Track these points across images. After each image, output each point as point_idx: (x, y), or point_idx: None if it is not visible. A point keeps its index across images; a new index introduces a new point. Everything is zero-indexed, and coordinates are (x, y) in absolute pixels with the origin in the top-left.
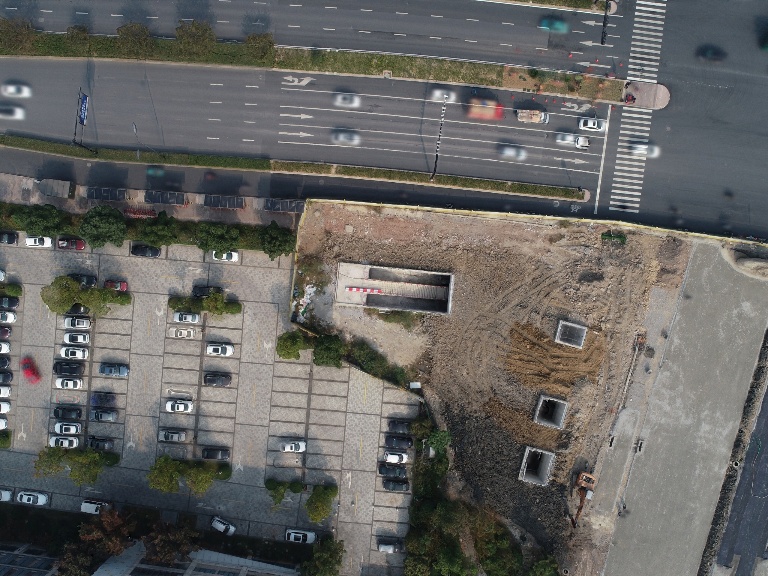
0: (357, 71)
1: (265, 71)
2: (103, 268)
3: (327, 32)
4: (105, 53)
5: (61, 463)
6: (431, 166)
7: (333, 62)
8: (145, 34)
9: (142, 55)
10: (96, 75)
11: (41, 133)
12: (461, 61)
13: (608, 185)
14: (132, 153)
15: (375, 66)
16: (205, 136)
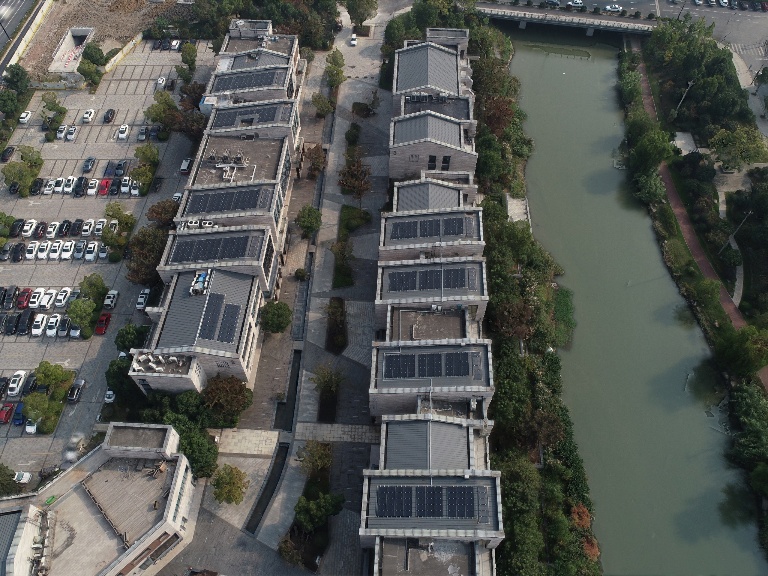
0: None
1: None
2: None
3: None
4: None
5: (154, 190)
6: (3, 42)
7: None
8: None
9: None
10: None
11: None
12: None
13: None
14: None
15: None
16: None
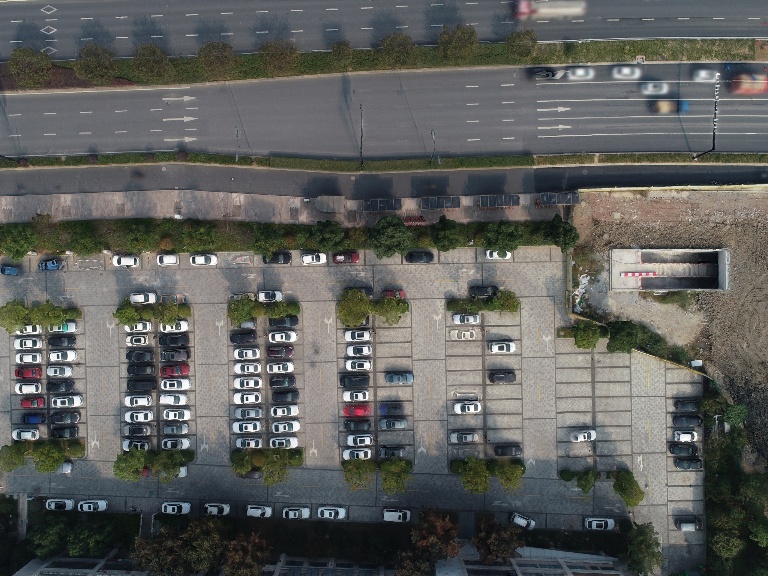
0: (610, 59)
1: (519, 68)
2: (377, 279)
3: (576, 24)
4: (361, 67)
5: None
6: (691, 145)
7: (586, 53)
8: (409, 43)
9: (407, 64)
10: (352, 89)
11: (303, 152)
12: (712, 39)
13: None
14: (397, 162)
15: (628, 52)
16: (465, 138)
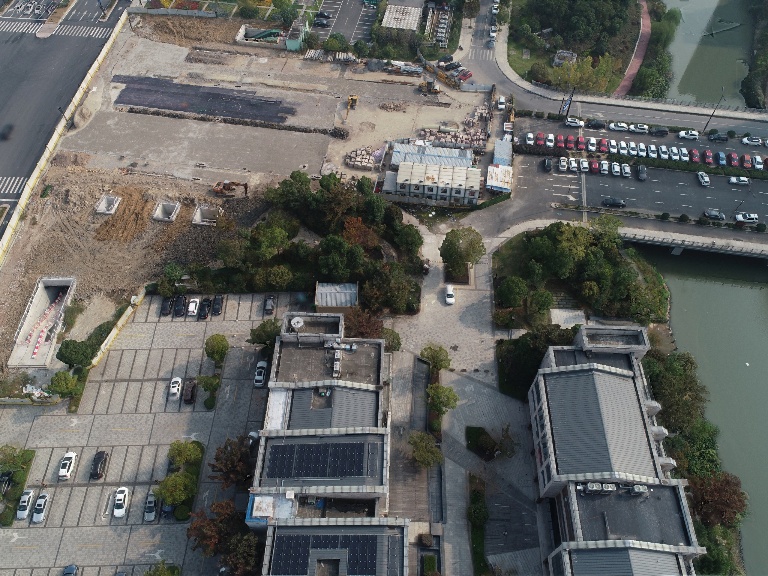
0: None
1: None
2: None
3: None
4: None
5: None
6: None
7: None
8: None
9: None
10: None
11: None
12: None
13: (1, 195)
14: None
15: None
16: None
